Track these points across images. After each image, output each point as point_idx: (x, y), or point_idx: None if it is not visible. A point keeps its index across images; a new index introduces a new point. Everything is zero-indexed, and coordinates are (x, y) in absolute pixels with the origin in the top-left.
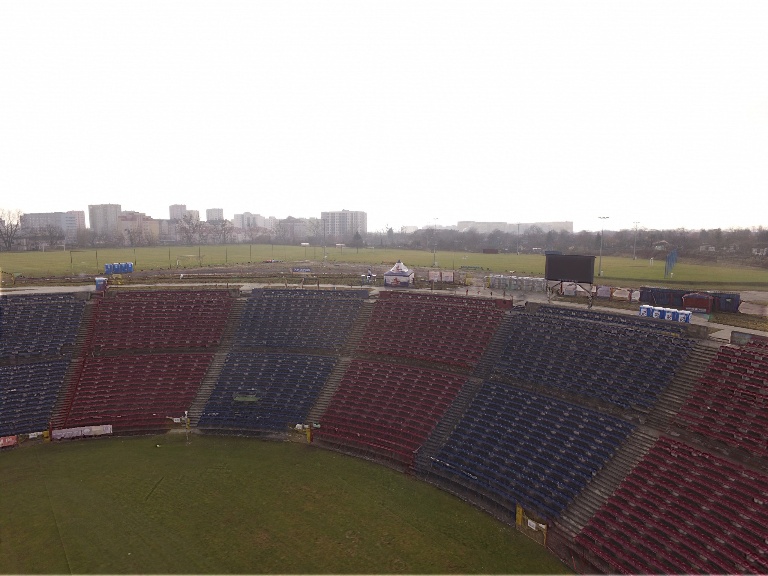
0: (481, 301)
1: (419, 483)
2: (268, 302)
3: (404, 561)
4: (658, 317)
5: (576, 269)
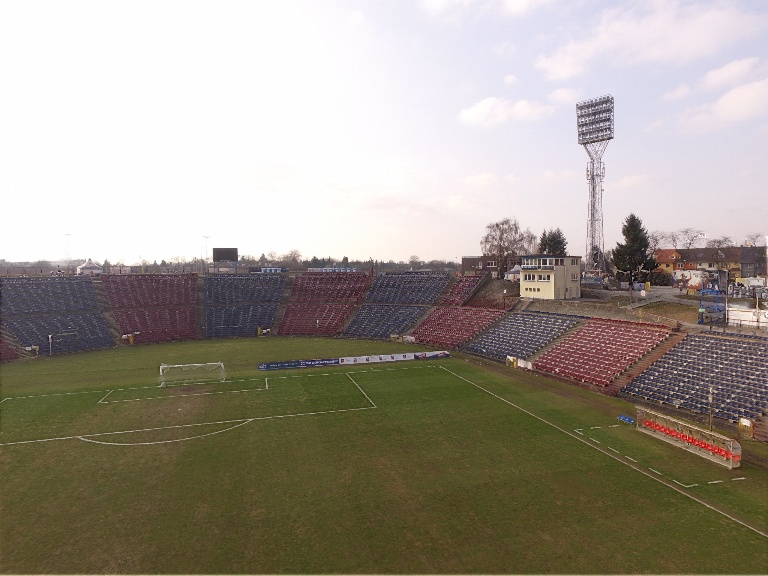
0: (178, 275)
1: (208, 340)
2: (2, 286)
3: (234, 345)
4: (269, 272)
5: (229, 255)
